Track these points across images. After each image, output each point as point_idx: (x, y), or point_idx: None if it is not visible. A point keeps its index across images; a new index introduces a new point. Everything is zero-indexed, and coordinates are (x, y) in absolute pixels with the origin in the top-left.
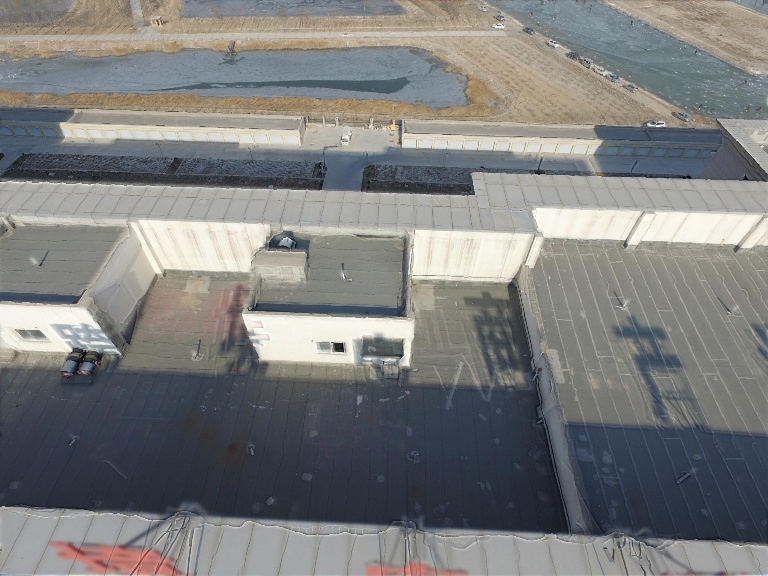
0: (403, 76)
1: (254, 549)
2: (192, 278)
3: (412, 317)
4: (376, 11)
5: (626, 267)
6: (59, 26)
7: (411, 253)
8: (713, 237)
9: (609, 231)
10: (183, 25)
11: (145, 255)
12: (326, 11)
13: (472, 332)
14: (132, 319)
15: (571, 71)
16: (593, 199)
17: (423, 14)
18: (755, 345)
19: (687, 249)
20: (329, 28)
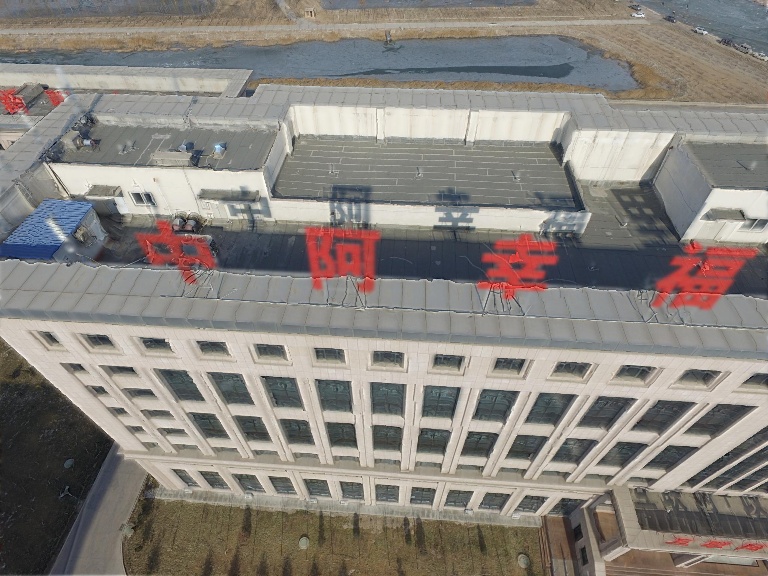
0: (565, 62)
1: None
2: None
3: None
4: (508, 2)
5: None
6: (217, 18)
7: None
8: None
9: None
10: (333, 16)
11: None
12: (459, 2)
13: None
14: None
15: (730, 57)
16: None
17: (556, 4)
18: None
19: None
20: (473, 18)
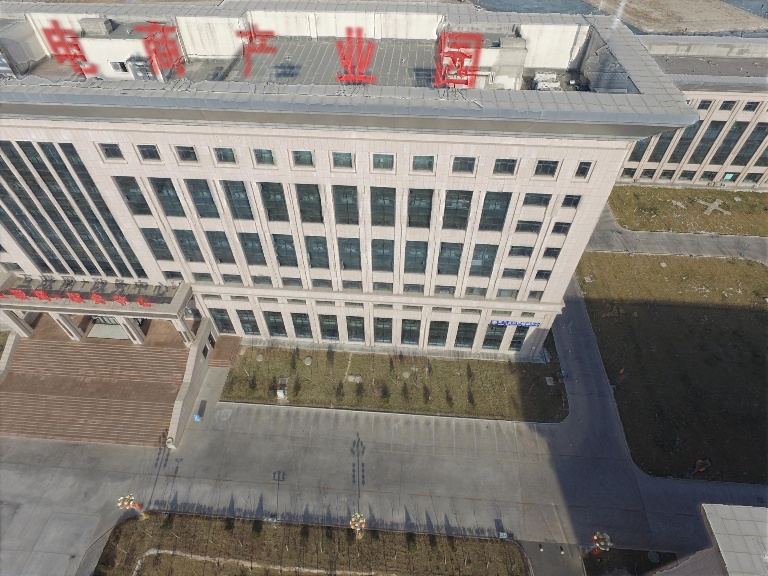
0: None
1: (32, 77)
2: (68, 60)
3: (149, 39)
4: None
5: (305, 47)
6: None
7: (177, 33)
8: (359, 32)
9: (299, 29)
10: None
11: (38, 40)
12: None
13: (210, 76)
14: (26, 67)
15: None
16: (284, 7)
17: None
18: (344, 69)
19: (348, 42)
20: None
